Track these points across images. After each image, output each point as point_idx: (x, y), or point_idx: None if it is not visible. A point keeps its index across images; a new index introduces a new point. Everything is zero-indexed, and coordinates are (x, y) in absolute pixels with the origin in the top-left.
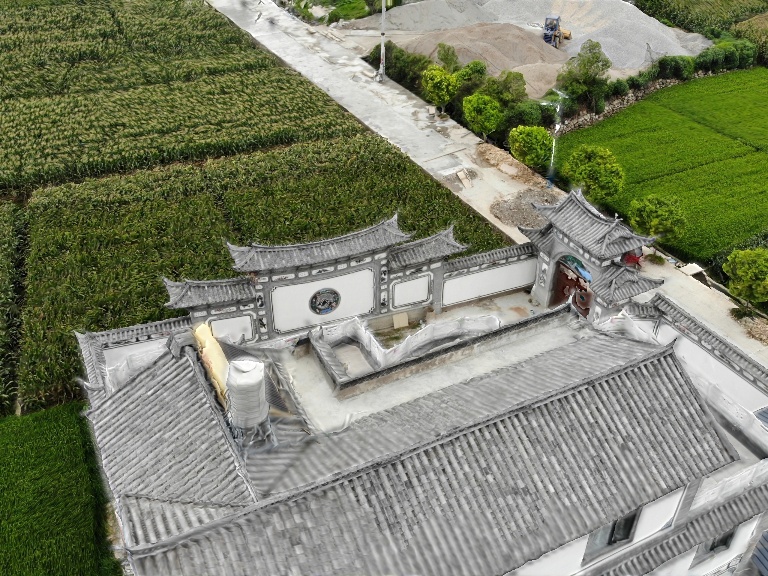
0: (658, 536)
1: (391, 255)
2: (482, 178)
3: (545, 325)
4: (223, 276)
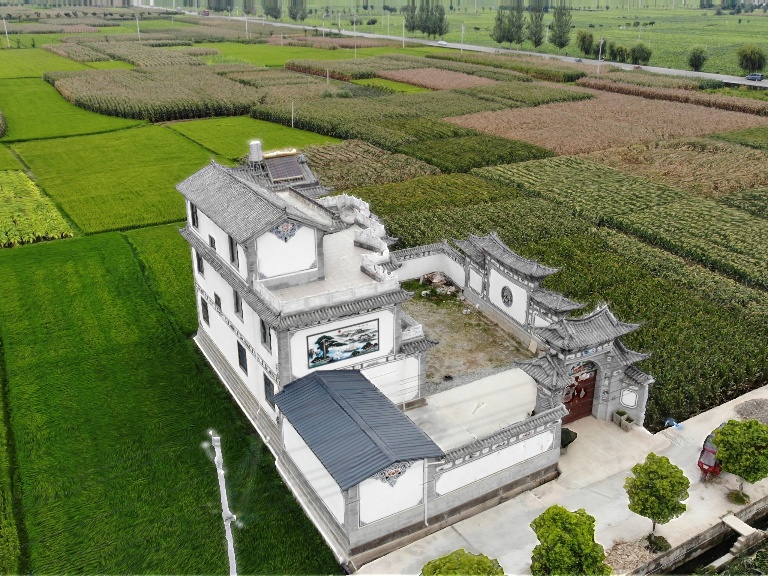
0: None
1: (537, 289)
2: None
3: None
4: (549, 287)
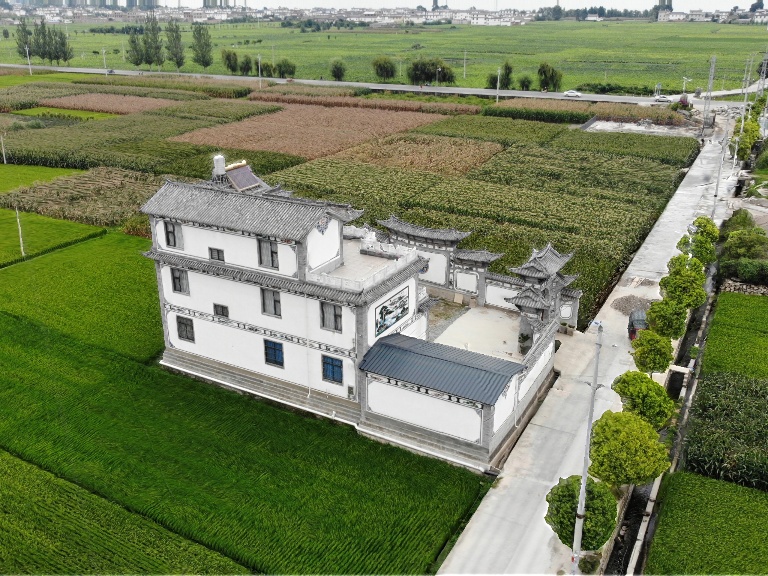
0: (291, 279)
1: (457, 251)
2: (651, 288)
3: (339, 211)
4: None
